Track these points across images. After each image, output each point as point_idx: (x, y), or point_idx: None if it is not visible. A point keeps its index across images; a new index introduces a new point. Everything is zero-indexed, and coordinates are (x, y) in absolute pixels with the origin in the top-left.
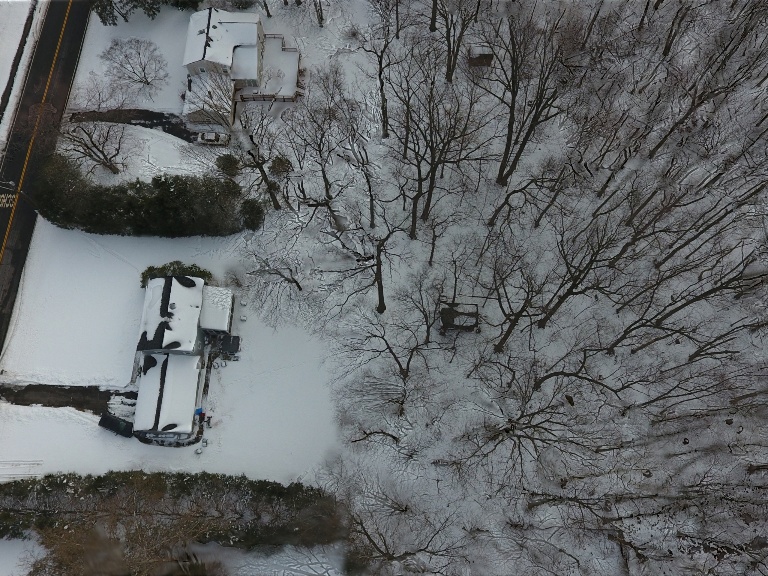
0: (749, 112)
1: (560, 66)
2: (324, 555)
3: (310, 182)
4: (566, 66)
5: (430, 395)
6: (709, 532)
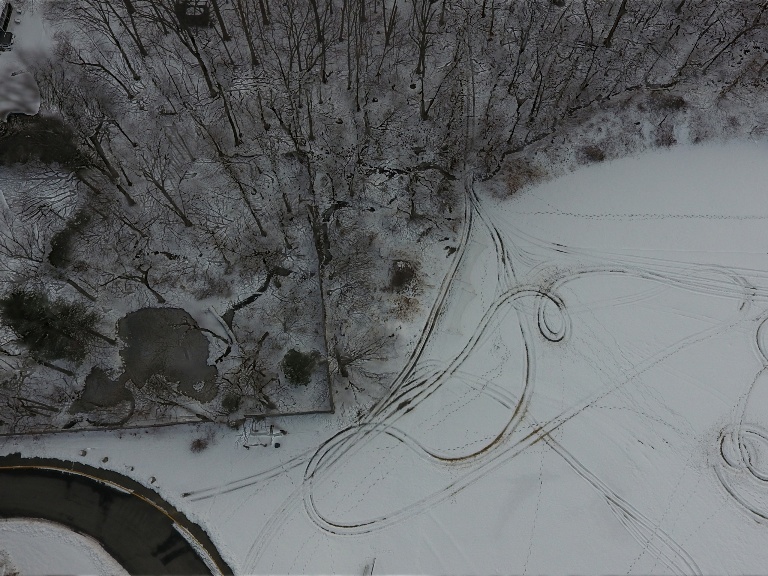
0: None
1: None
2: (59, 168)
3: None
4: None
5: None
6: (384, 159)
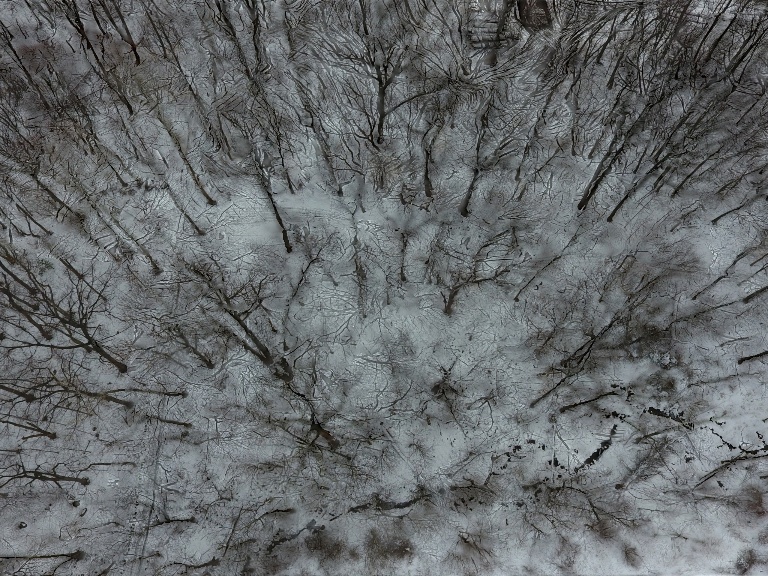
0: None
1: None
2: None
3: None
4: (25, 127)
5: None
6: None
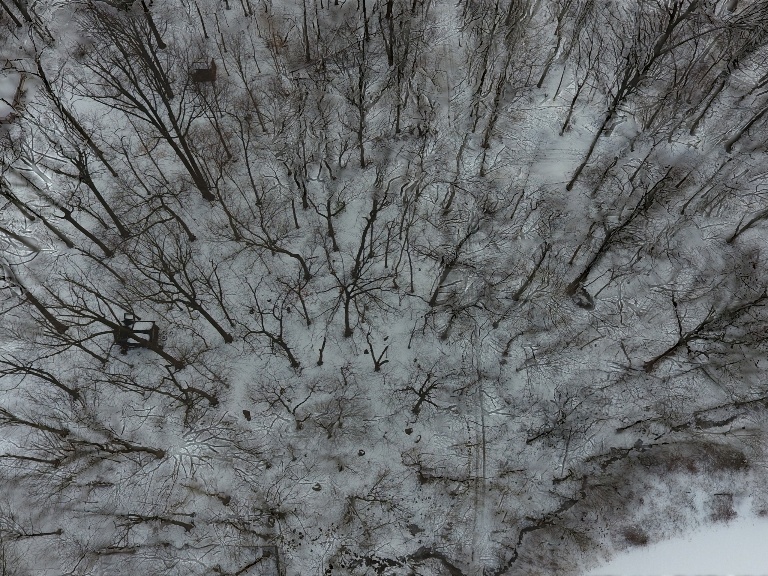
0: (466, 119)
1: (283, 79)
2: None
3: (1, 204)
4: (289, 79)
5: (94, 415)
6: (372, 545)
